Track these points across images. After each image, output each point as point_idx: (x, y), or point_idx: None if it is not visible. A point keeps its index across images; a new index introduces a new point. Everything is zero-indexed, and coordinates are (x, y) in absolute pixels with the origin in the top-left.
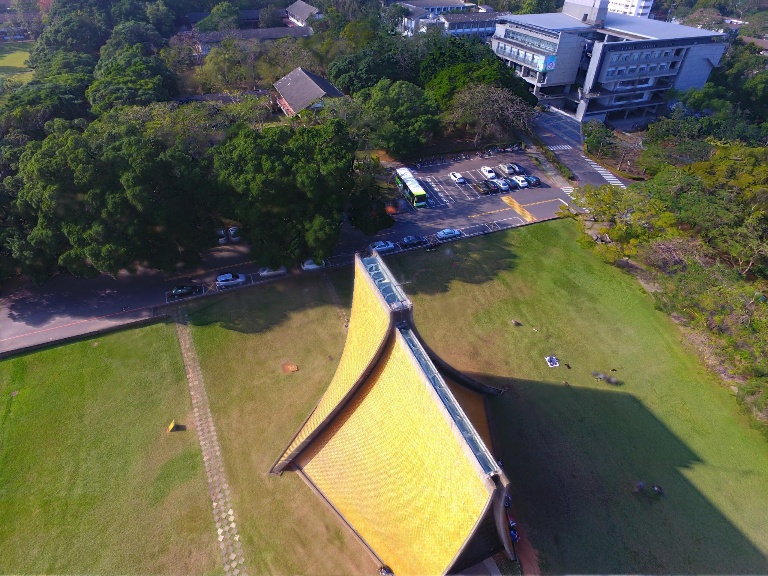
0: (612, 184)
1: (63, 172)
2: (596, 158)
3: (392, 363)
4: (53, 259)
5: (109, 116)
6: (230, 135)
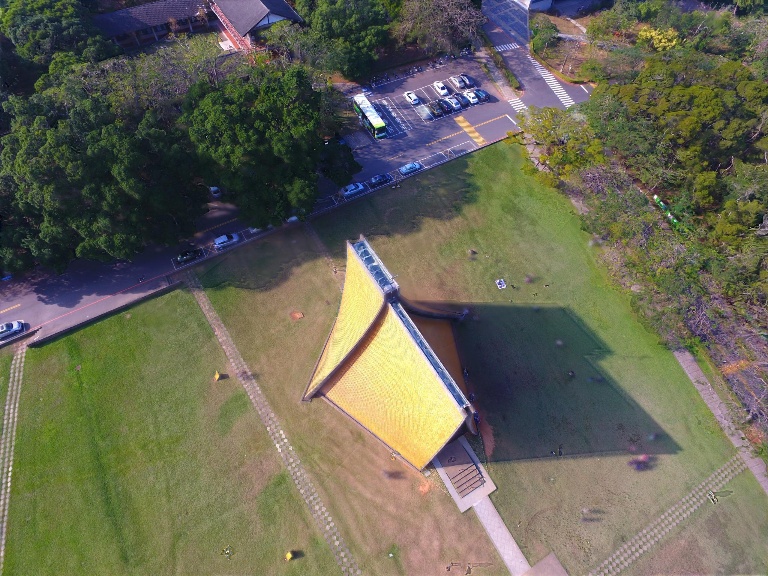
0: (554, 91)
1: (54, 171)
2: (541, 59)
3: (387, 325)
4: (67, 250)
5: (66, 89)
6: (194, 98)
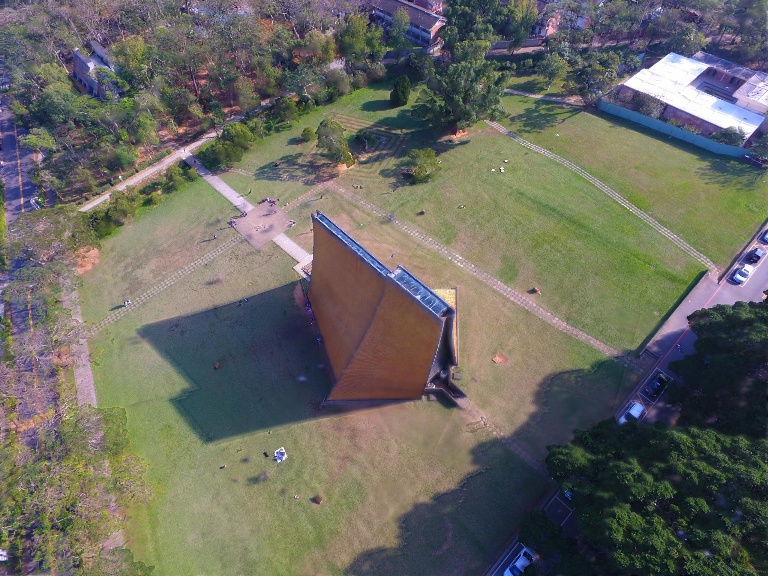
0: None
1: None
2: None
3: None
4: None
5: None
6: None
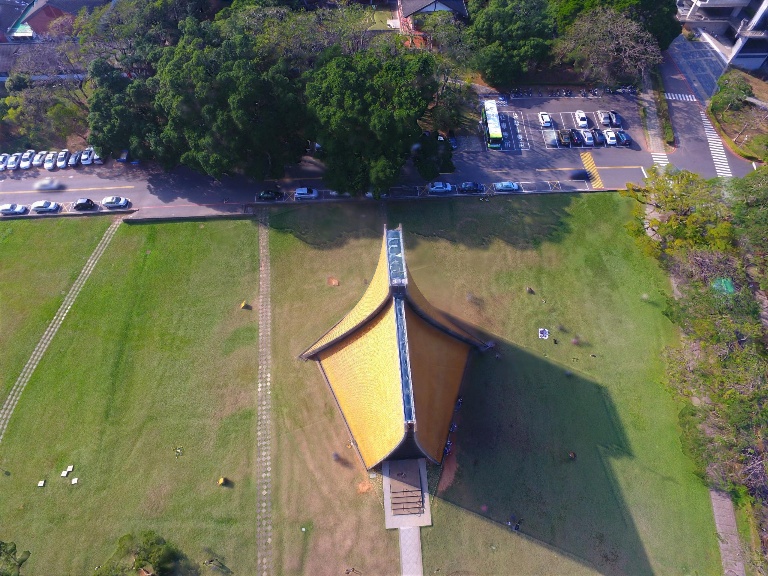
0: (714, 159)
1: (187, 85)
2: (716, 120)
3: (388, 318)
4: (177, 154)
5: (229, 22)
6: (326, 58)
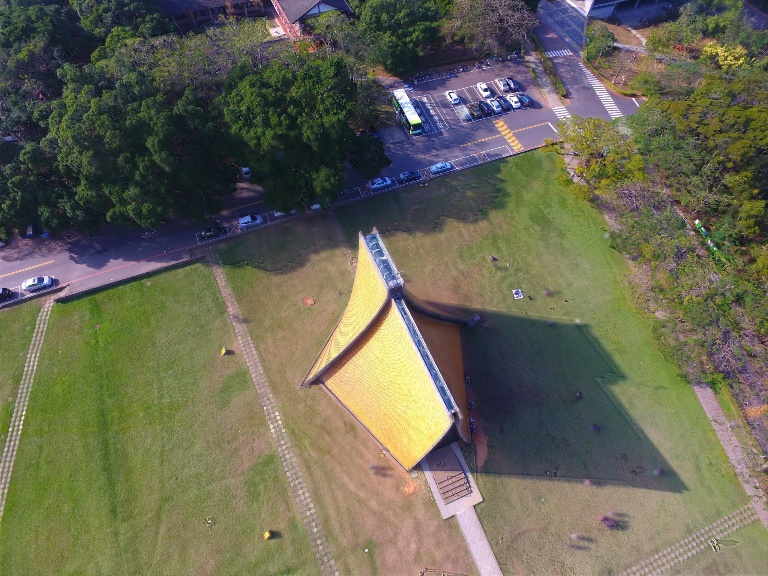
0: (603, 102)
1: (94, 138)
2: (593, 68)
3: (389, 321)
4: (99, 214)
5: (116, 61)
6: (234, 79)
